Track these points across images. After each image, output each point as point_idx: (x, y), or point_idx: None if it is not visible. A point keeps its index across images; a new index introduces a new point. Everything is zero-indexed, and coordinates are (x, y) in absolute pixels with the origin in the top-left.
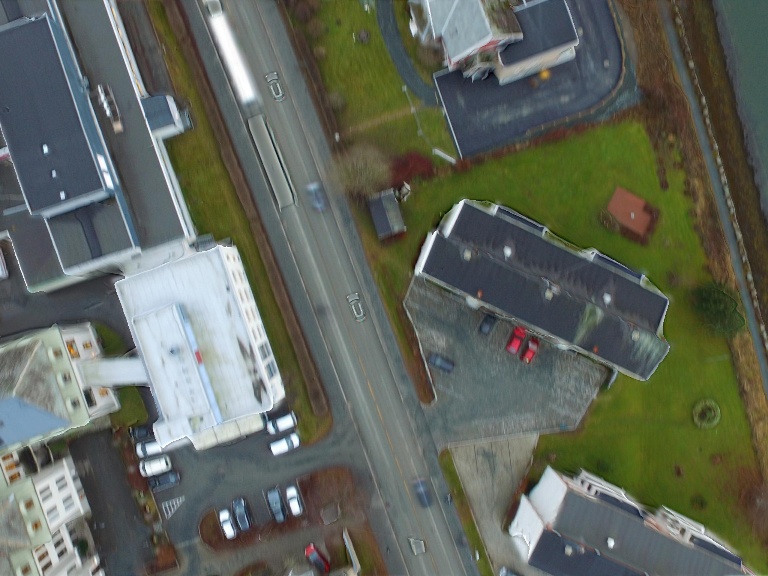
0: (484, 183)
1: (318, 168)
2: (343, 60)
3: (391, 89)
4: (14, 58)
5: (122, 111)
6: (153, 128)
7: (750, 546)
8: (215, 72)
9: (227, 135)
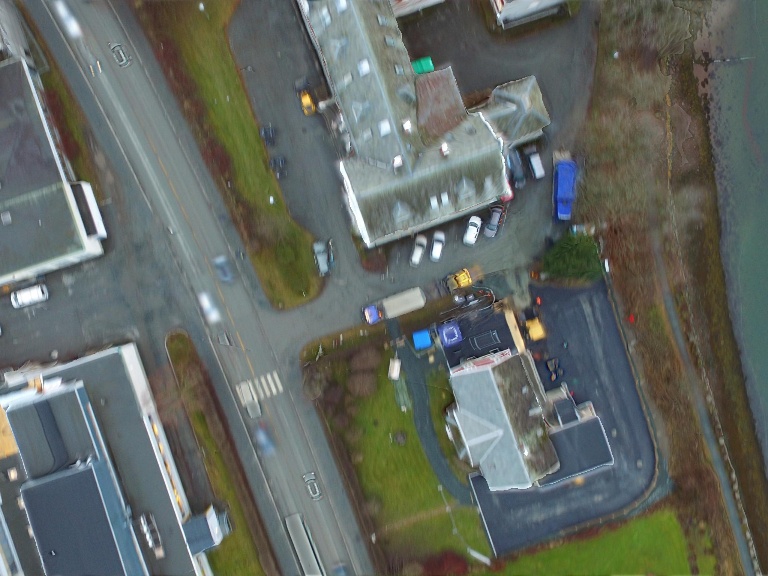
0: None
1: (354, 566)
2: (380, 460)
3: (427, 488)
4: (60, 508)
5: (164, 537)
6: (194, 552)
7: None
8: (253, 472)
9: (265, 537)
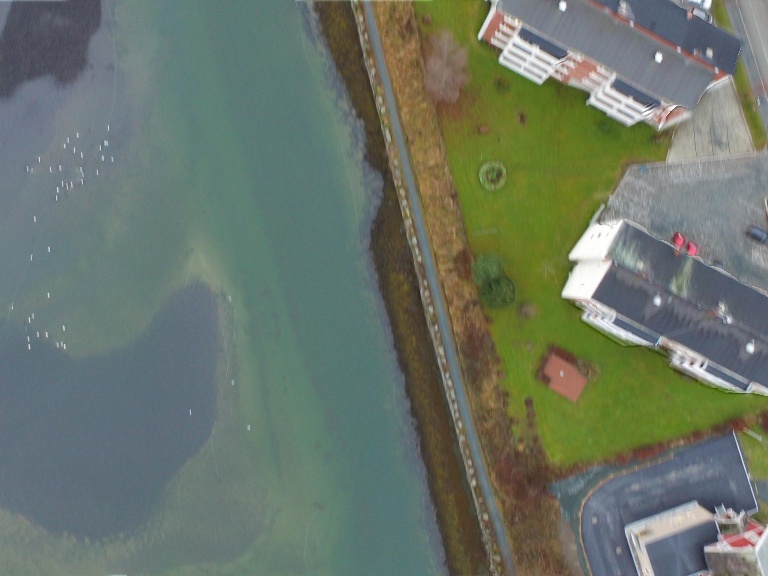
0: (711, 408)
1: None
2: None
3: None
4: None
5: None
6: None
7: (451, 39)
8: None
9: None
